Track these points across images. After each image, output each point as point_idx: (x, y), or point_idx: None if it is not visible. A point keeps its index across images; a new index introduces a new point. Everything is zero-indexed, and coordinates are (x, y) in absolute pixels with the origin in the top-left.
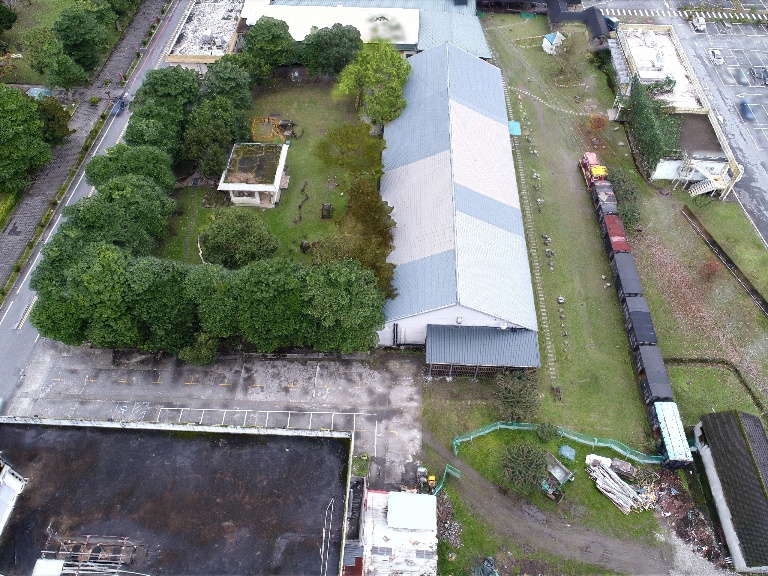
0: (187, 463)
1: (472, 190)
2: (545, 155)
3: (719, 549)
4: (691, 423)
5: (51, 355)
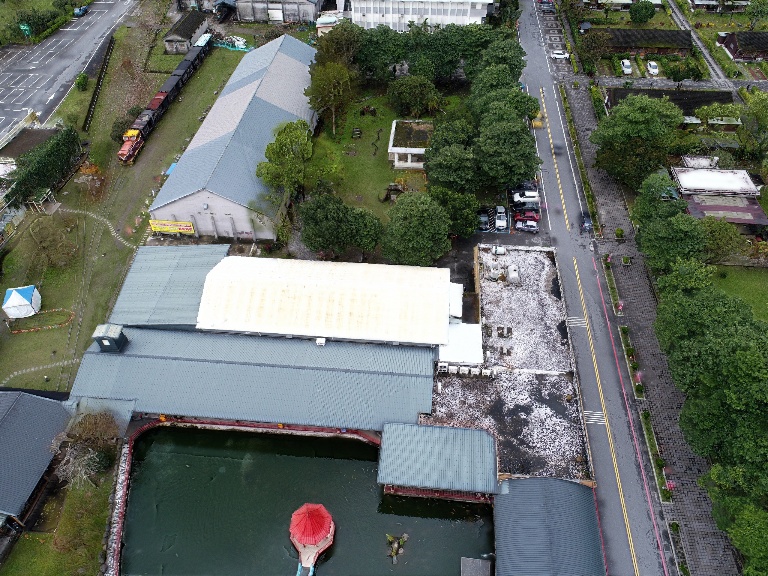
0: None
1: None
2: (156, 172)
3: None
4: None
5: None
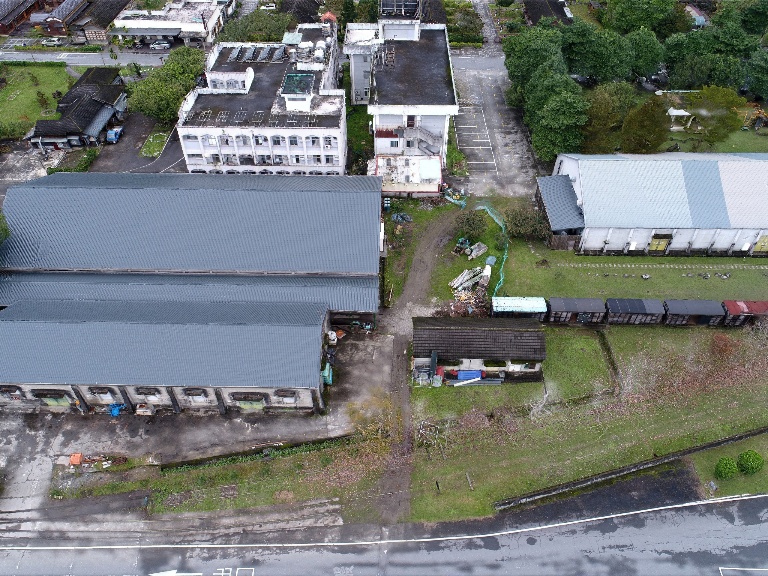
0: (434, 72)
1: (720, 179)
2: None
3: None
4: None
5: (504, 74)
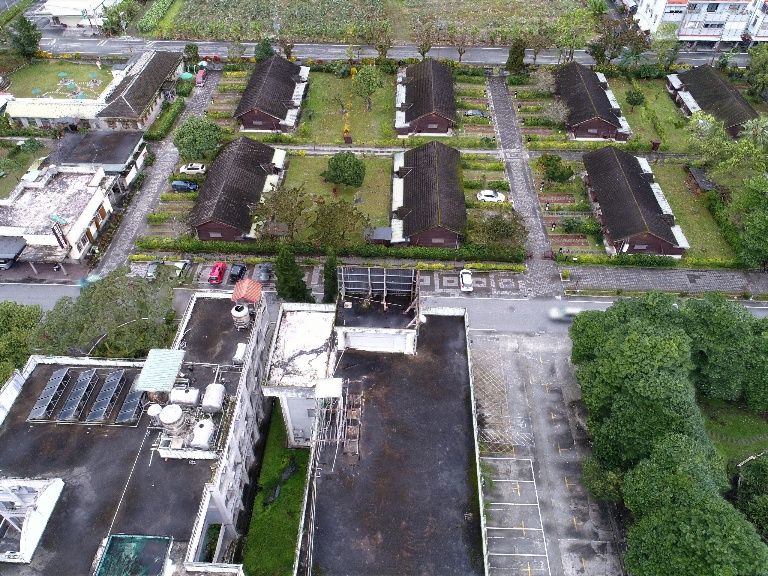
0: (442, 483)
1: None
2: None
3: None
4: None
5: (566, 349)
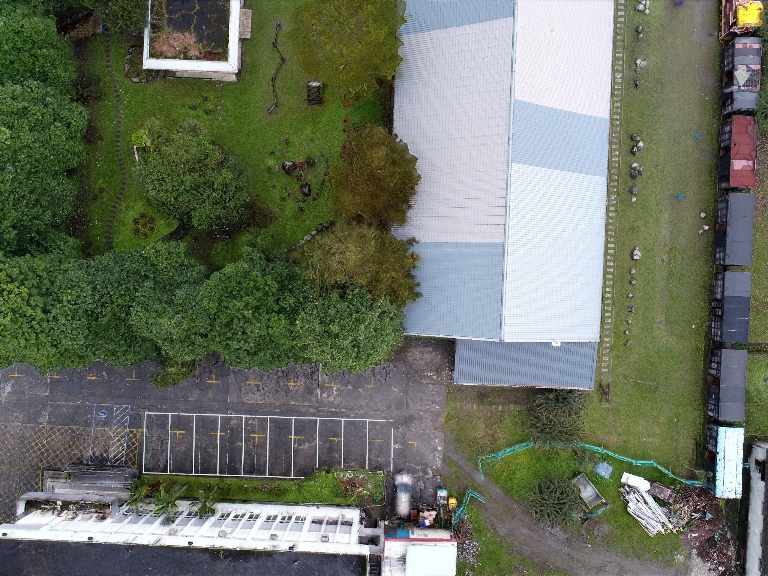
0: None
1: (541, 106)
2: None
3: (735, 568)
4: (752, 431)
5: None
